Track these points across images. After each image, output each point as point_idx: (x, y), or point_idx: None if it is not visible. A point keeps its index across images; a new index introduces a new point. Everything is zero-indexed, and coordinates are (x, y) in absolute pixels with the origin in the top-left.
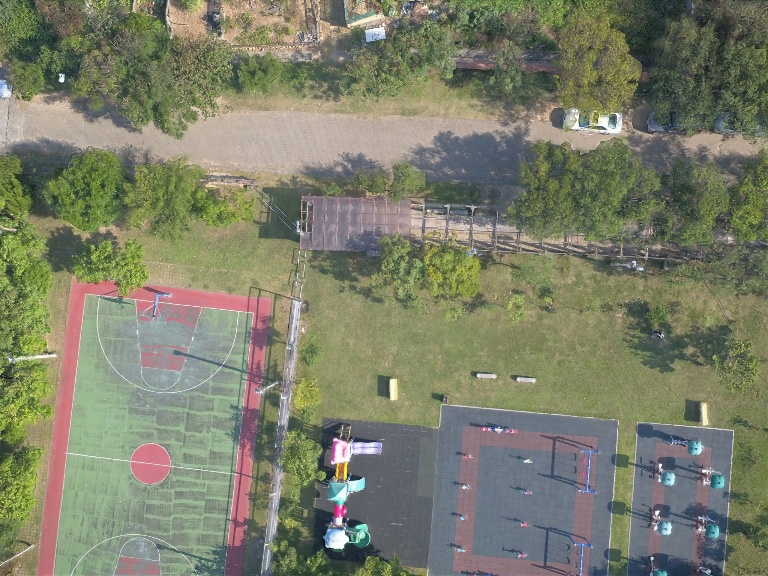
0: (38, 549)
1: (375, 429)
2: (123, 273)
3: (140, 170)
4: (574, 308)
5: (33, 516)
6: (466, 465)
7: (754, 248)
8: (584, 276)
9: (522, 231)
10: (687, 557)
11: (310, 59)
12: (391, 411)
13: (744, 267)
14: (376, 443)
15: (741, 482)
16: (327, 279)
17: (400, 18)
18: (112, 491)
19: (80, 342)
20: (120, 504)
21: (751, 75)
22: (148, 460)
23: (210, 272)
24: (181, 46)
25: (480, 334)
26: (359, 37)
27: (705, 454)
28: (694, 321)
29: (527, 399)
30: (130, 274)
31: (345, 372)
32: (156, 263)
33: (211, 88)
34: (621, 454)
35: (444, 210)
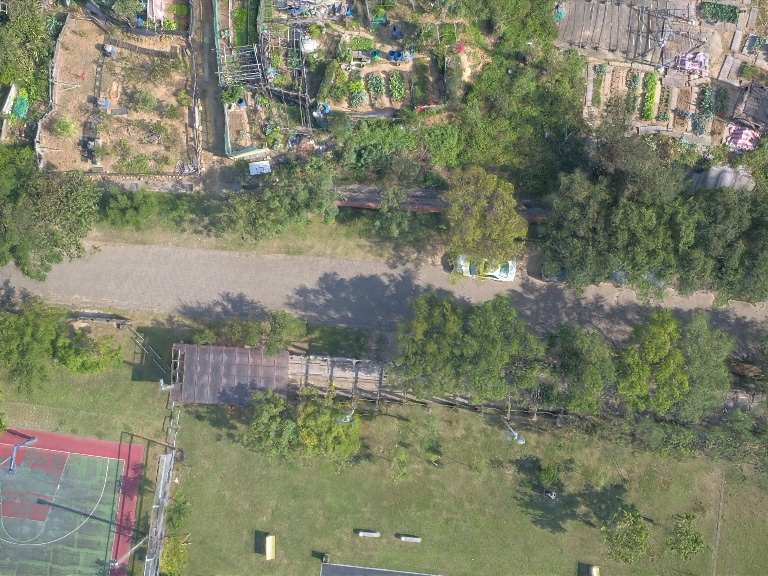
0: None
1: None
2: None
3: None
4: (463, 463)
5: None
6: None
7: (646, 413)
8: (474, 430)
9: None
10: None
11: (191, 190)
12: (268, 569)
13: (630, 442)
14: None
15: None
16: (203, 426)
17: (285, 152)
18: None
19: None
20: None
21: (639, 241)
22: None
23: (79, 415)
24: (41, 186)
25: (364, 489)
26: (243, 169)
27: None
28: (588, 480)
29: (412, 559)
30: None
31: (220, 526)
32: (21, 404)
33: (76, 228)
34: None
35: None
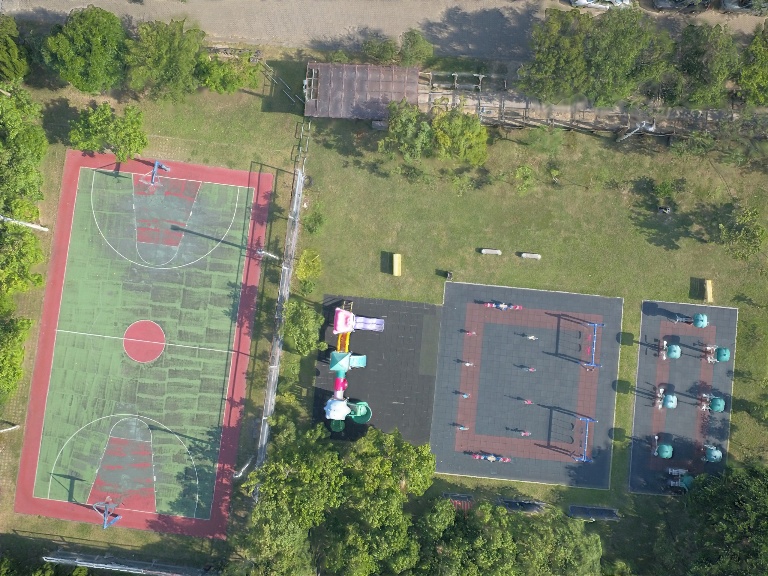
0: (23, 430)
1: (377, 306)
2: (122, 136)
3: (143, 27)
4: (580, 185)
5: (19, 396)
6: (470, 343)
7: None
8: (590, 153)
9: (528, 107)
10: (691, 436)
11: None
12: (394, 288)
13: (752, 128)
14: (378, 320)
15: (745, 361)
16: (331, 153)
17: None
18: (103, 369)
19: (73, 216)
20: (111, 383)
21: None
22: (142, 337)
23: (210, 146)
24: None
25: (485, 210)
26: None
27: (709, 332)
28: (699, 199)
29: (532, 276)
30: (129, 138)
31: (347, 248)
32: (155, 136)
33: None
34: (626, 332)
35: (450, 84)
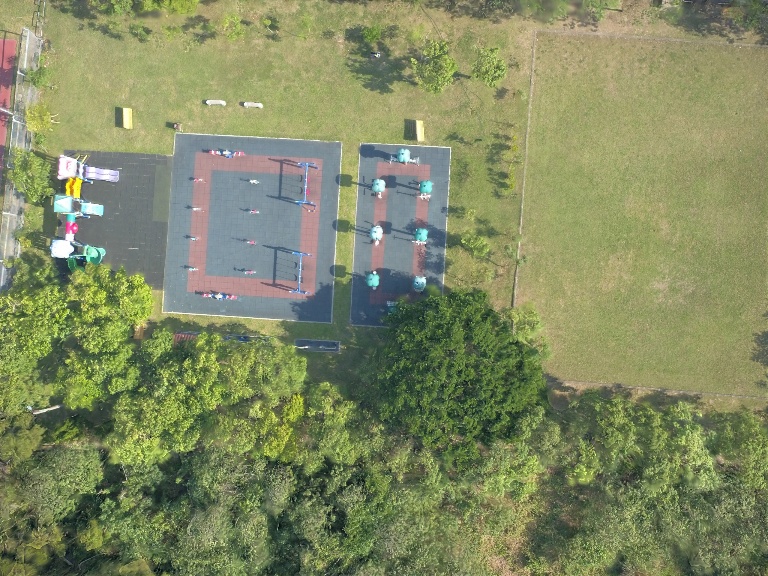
0: None
1: (113, 159)
2: None
3: None
4: (299, 36)
5: None
6: (199, 190)
7: None
8: (307, 5)
9: None
10: (408, 271)
11: None
12: (128, 141)
13: None
14: (113, 171)
15: (458, 197)
16: (67, 17)
17: None
18: None
19: None
20: None
21: None
22: None
23: None
24: None
25: (211, 64)
26: None
27: (424, 171)
28: (411, 43)
29: (255, 124)
30: None
31: (85, 106)
32: None
33: None
34: (345, 174)
35: None
